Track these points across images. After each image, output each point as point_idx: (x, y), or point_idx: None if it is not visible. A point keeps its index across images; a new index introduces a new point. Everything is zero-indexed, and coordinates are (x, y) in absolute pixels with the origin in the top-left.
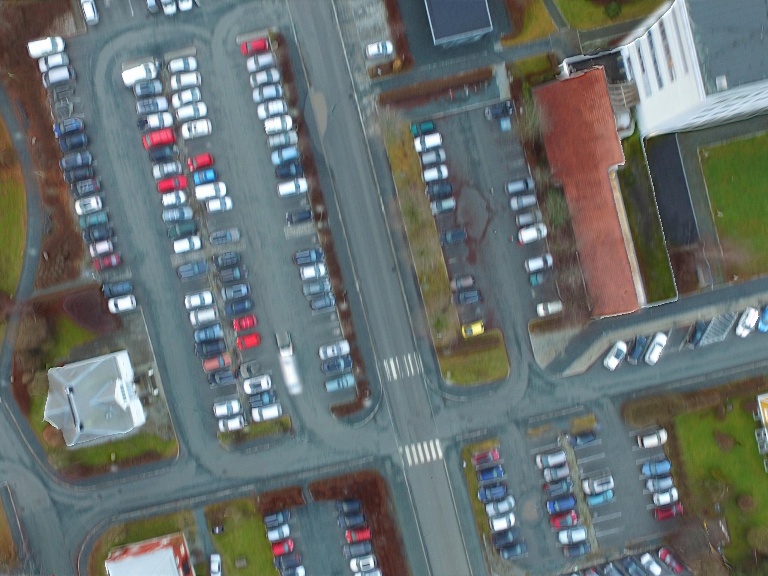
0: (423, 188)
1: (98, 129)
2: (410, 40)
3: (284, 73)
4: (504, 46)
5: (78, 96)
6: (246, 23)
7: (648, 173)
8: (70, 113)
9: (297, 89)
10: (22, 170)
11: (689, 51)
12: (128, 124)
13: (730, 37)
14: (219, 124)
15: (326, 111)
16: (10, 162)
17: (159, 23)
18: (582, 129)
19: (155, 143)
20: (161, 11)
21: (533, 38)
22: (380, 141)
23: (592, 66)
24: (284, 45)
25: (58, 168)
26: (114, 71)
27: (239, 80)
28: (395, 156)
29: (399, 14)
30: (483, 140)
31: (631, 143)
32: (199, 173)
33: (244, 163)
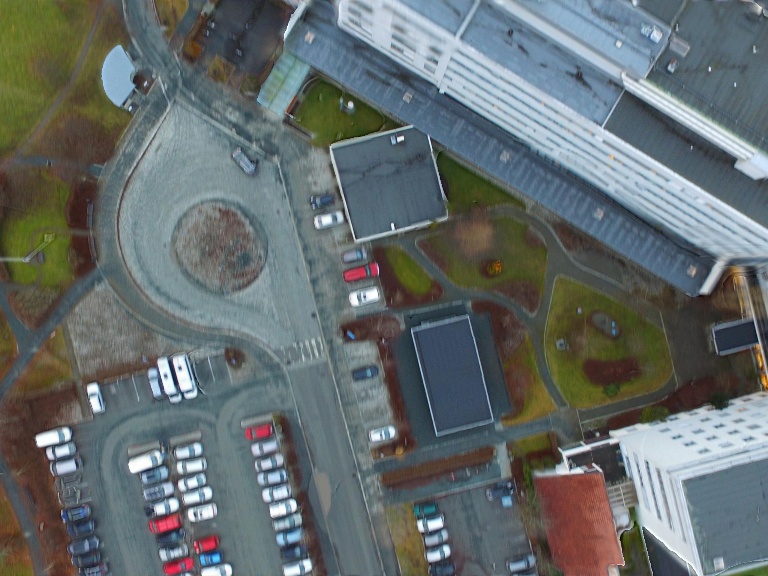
0: (426, 567)
1: (105, 512)
2: (412, 422)
3: (288, 456)
4: (505, 426)
5: (85, 481)
6: (250, 407)
7: (647, 560)
8: (77, 500)
9: (301, 470)
10: (30, 553)
11: (687, 530)
12: (135, 506)
13: (727, 518)
14: (224, 505)
15: (330, 490)
16: (18, 548)
17: (165, 407)
18: (582, 526)
19: (162, 531)
20: (167, 397)
21: (533, 418)
22: (383, 519)
23: (591, 463)
24: (288, 429)
25: (66, 552)
26: (120, 455)
27: (244, 462)
28: (398, 535)
29: (401, 398)
30: (485, 517)
31: (630, 532)
32: (205, 556)
33: (249, 542)
